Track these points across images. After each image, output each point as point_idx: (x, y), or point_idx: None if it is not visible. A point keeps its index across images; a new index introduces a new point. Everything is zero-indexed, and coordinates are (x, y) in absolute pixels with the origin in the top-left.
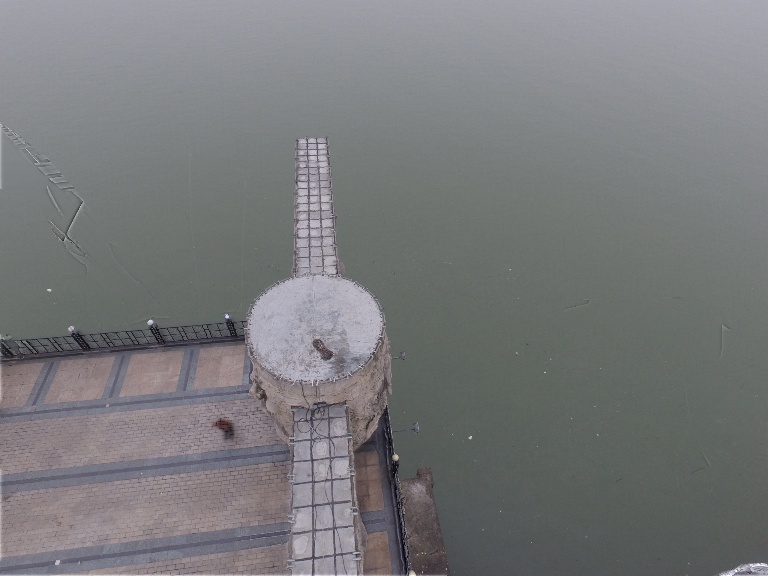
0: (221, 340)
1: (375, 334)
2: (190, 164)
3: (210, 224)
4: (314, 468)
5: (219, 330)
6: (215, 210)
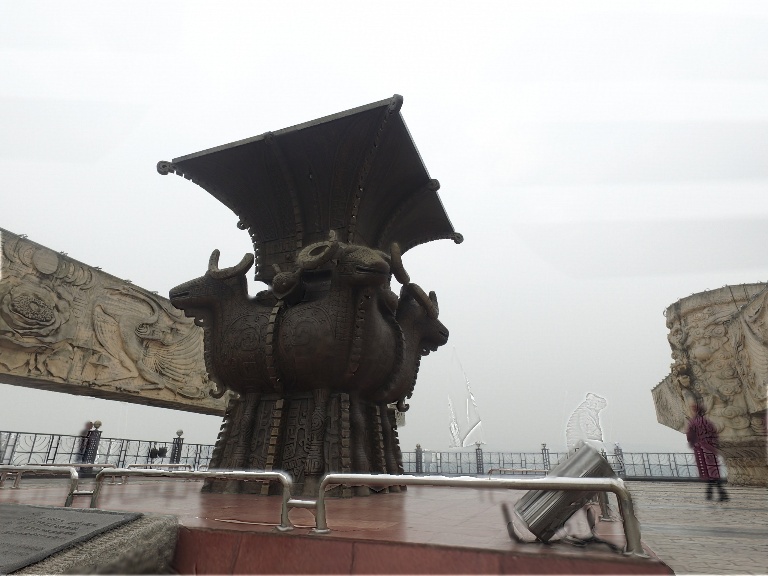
0: None
1: None
2: (565, 399)
3: None
4: None
5: None
6: None
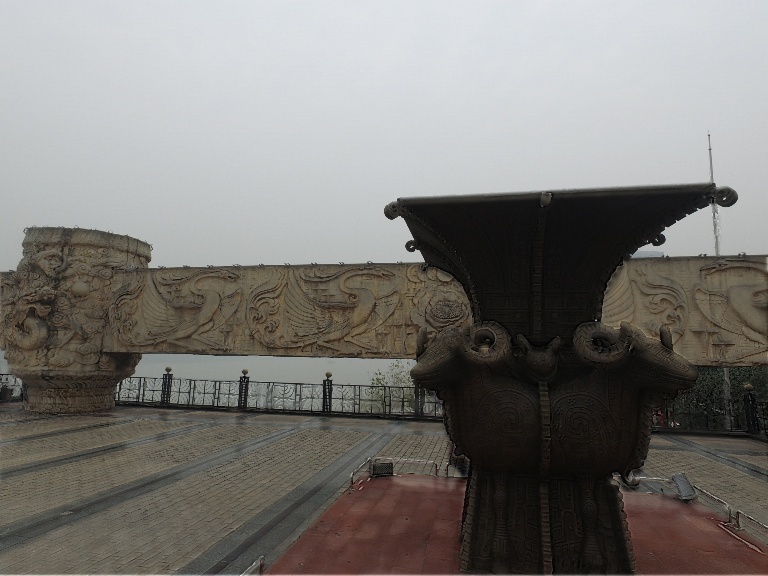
0: None
1: None
2: None
3: None
4: None
5: None
6: None
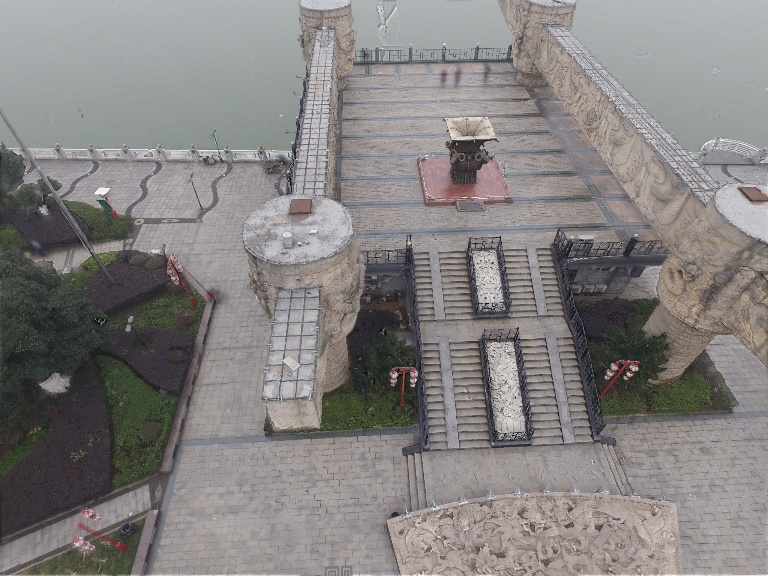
0: (470, 61)
1: (574, 0)
2: None
3: (449, 23)
4: (558, 32)
5: (471, 54)
6: (455, 13)
